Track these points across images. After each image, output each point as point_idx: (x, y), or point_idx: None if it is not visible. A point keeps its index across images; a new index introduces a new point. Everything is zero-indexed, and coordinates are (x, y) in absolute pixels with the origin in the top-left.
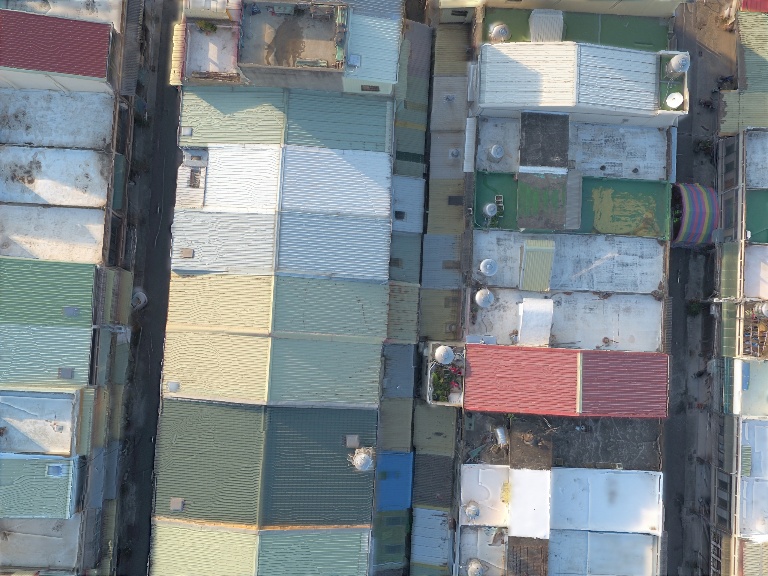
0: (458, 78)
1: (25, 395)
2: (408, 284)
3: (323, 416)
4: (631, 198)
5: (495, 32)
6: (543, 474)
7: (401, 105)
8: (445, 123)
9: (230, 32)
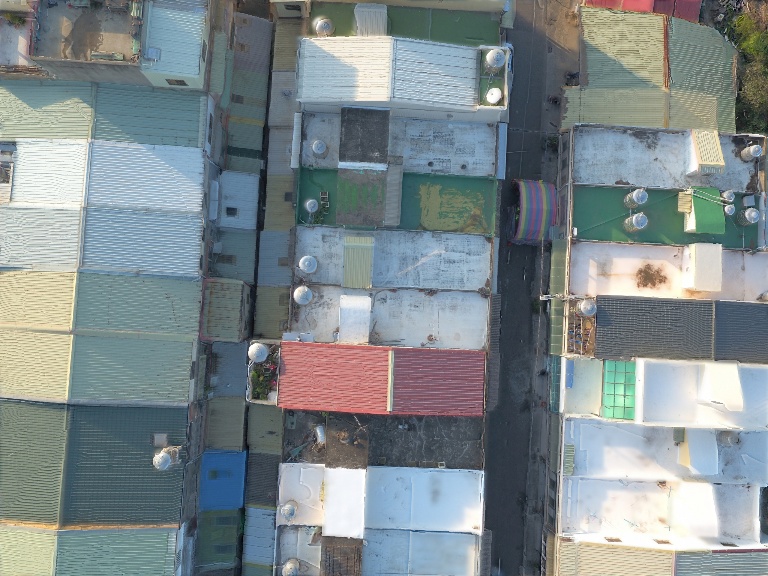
0: None
1: None
2: (231, 281)
3: (129, 415)
4: (459, 194)
5: (318, 26)
6: (358, 473)
7: (225, 100)
8: (282, 119)
9: None
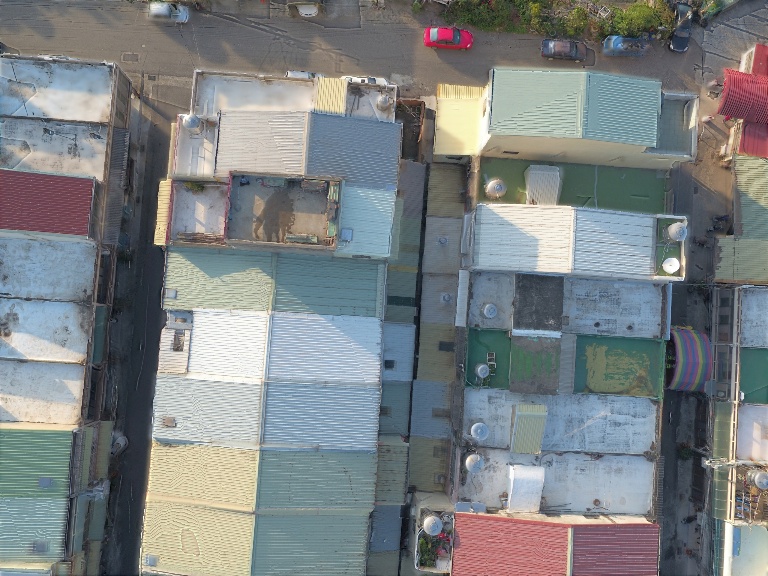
0: (451, 220)
1: None
2: (397, 443)
3: None
4: (625, 356)
5: (490, 188)
6: None
7: None
8: (437, 266)
9: (217, 191)
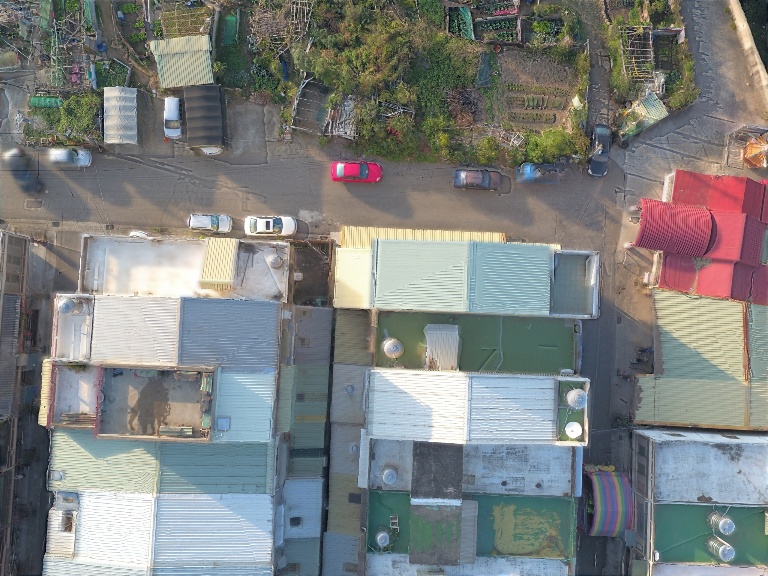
0: (358, 367)
1: None
2: None
3: None
4: (534, 515)
5: (386, 349)
6: None
7: (290, 422)
8: (344, 416)
9: None
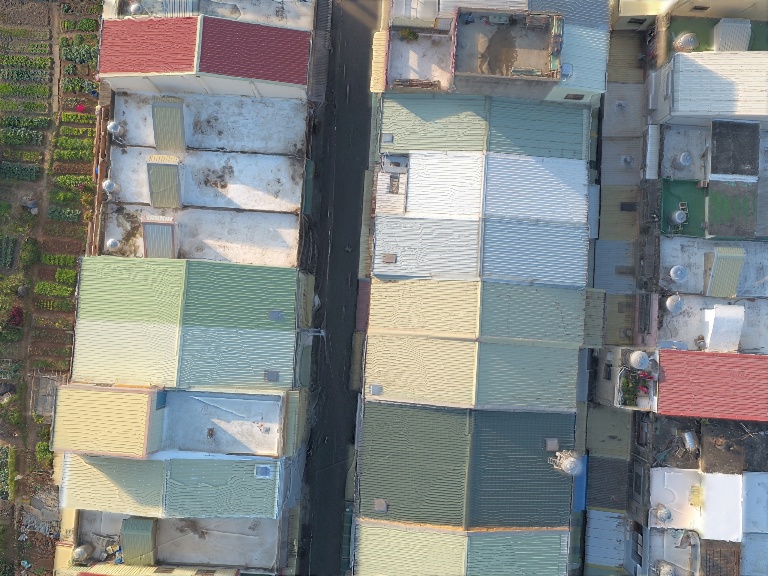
0: (630, 85)
1: (232, 397)
2: (594, 289)
3: (524, 420)
4: None
5: (683, 40)
6: (735, 478)
7: None
8: (618, 129)
9: (430, 40)
